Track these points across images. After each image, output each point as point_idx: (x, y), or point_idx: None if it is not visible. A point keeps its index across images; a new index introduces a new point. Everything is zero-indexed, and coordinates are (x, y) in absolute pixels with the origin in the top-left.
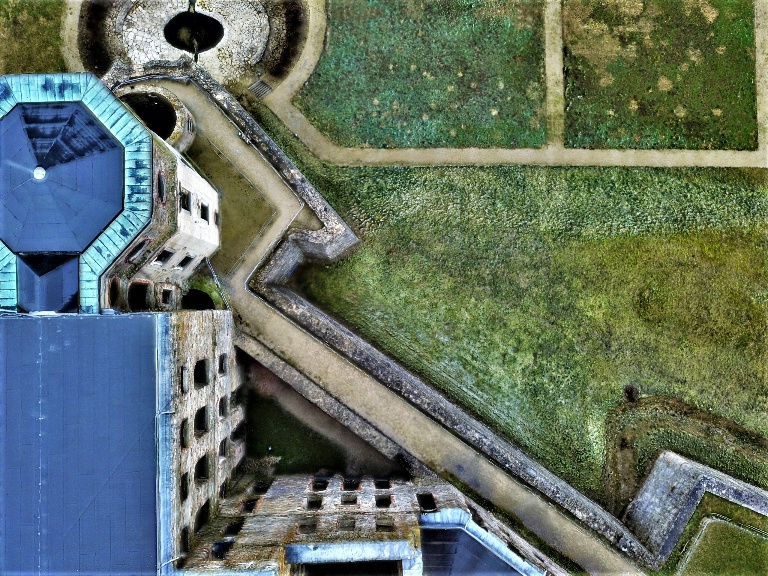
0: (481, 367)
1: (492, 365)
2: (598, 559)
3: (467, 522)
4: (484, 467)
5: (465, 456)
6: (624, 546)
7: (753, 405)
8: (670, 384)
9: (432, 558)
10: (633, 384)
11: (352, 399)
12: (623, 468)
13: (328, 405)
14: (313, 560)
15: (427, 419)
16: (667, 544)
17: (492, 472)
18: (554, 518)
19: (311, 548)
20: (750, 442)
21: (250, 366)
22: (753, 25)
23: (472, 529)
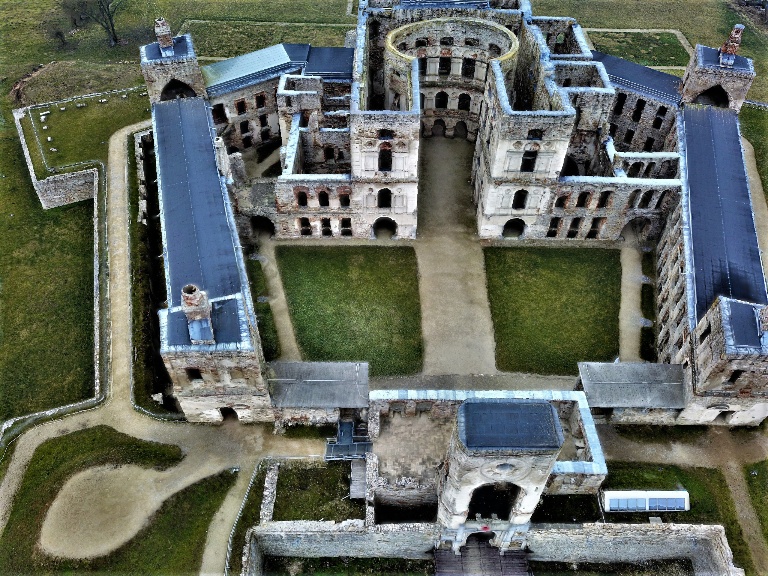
0: None
1: None
2: None
3: None
4: None
5: None
6: None
7: None
8: None
9: None
10: None
11: None
12: None
13: None
14: (535, 18)
15: None
16: None
17: None
18: None
19: None
20: None
21: None
22: (678, 39)
23: None
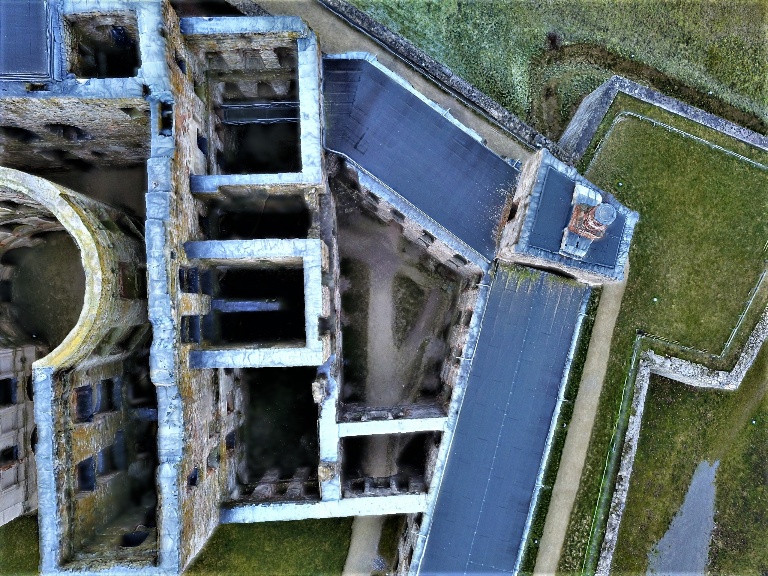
0: (407, 15)
1: (417, 14)
2: (514, 157)
3: (371, 58)
4: (402, 71)
5: (383, 61)
6: (539, 143)
7: (675, 53)
8: (593, 32)
9: (336, 85)
10: (556, 32)
11: (272, 6)
12: (548, 117)
13: (248, 8)
14: (209, 30)
15: (345, 25)
16: (581, 142)
17: (410, 76)
18: (471, 119)
19: (207, 19)
20: (673, 94)
21: (178, 3)
22: None
23: (377, 65)
